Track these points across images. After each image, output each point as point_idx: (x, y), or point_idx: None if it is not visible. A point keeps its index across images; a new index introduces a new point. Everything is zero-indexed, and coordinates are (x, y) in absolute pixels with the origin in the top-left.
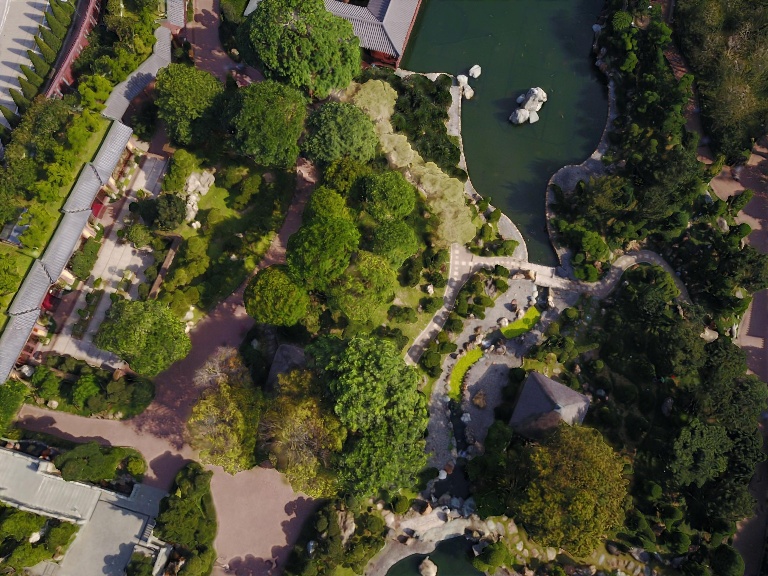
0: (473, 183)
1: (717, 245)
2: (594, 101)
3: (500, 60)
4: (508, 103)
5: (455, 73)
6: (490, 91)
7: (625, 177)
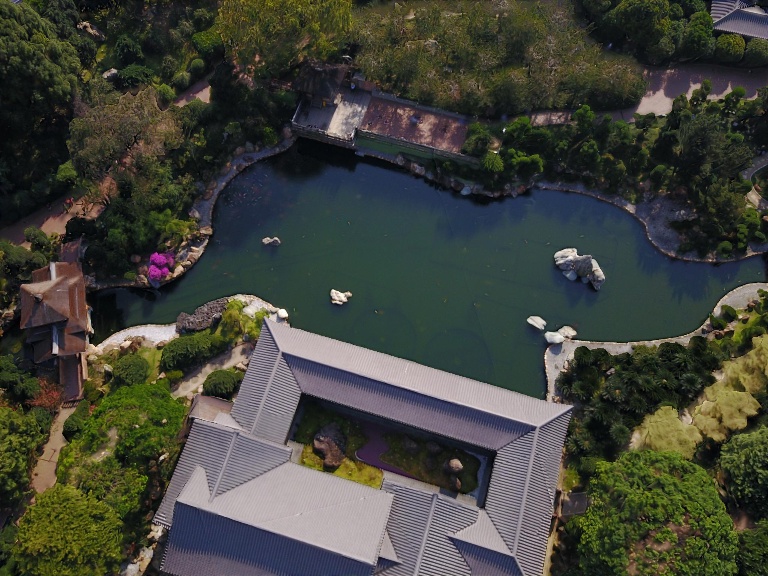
0: (684, 333)
1: (748, 117)
2: (561, 204)
3: (510, 295)
4: (573, 290)
5: (536, 347)
6: (556, 309)
7: (662, 185)
